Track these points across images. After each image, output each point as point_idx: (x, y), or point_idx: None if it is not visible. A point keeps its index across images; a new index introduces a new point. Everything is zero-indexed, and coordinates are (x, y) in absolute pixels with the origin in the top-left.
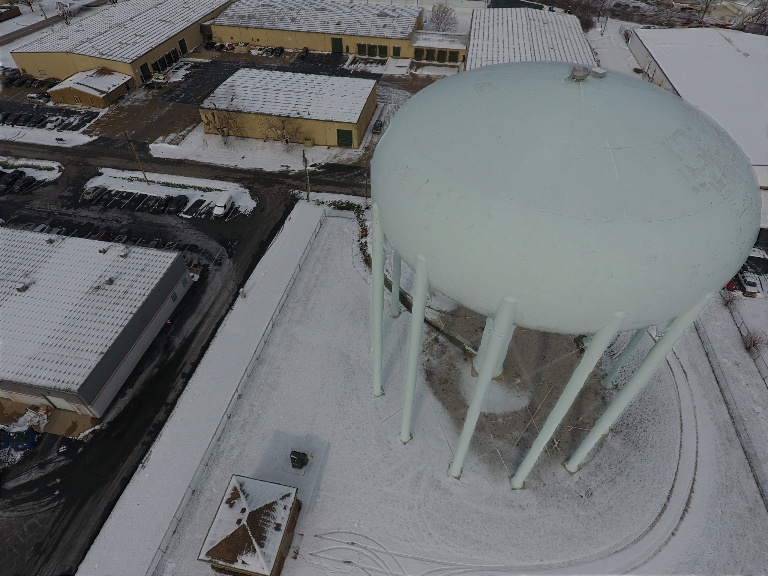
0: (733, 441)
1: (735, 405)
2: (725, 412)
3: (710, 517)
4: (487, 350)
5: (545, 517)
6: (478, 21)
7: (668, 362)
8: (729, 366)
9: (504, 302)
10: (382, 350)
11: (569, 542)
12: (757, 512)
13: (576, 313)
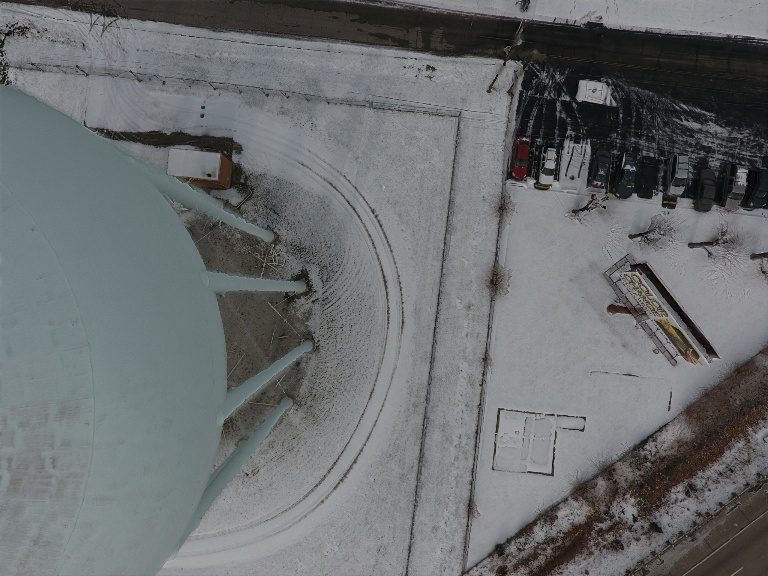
0: (418, 407)
1: (439, 364)
2: (425, 373)
3: (361, 485)
4: None
5: None
6: None
7: (388, 309)
8: (458, 310)
9: None
10: None
11: (226, 516)
12: (407, 478)
13: None
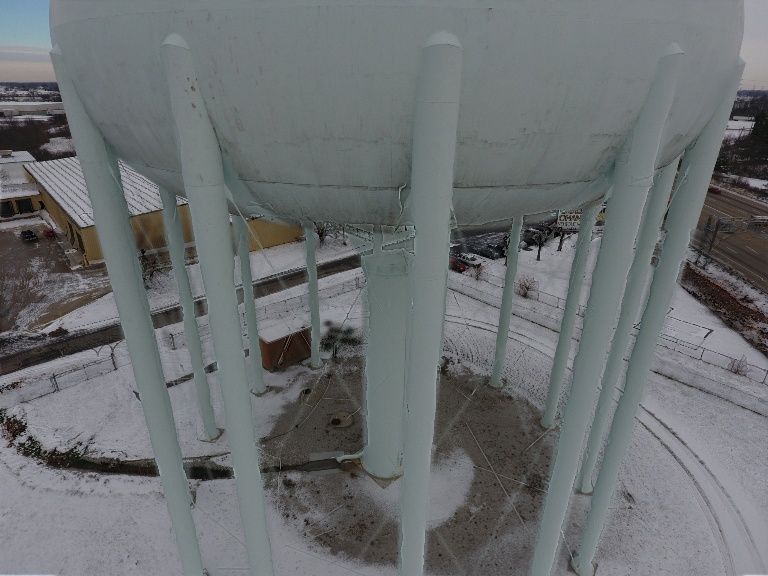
0: None
1: None
2: (576, 342)
3: (687, 422)
4: (616, 254)
5: (652, 574)
6: (38, 170)
7: None
8: (533, 312)
9: (664, 68)
10: (268, 541)
11: (700, 574)
12: (687, 392)
13: (722, 67)
